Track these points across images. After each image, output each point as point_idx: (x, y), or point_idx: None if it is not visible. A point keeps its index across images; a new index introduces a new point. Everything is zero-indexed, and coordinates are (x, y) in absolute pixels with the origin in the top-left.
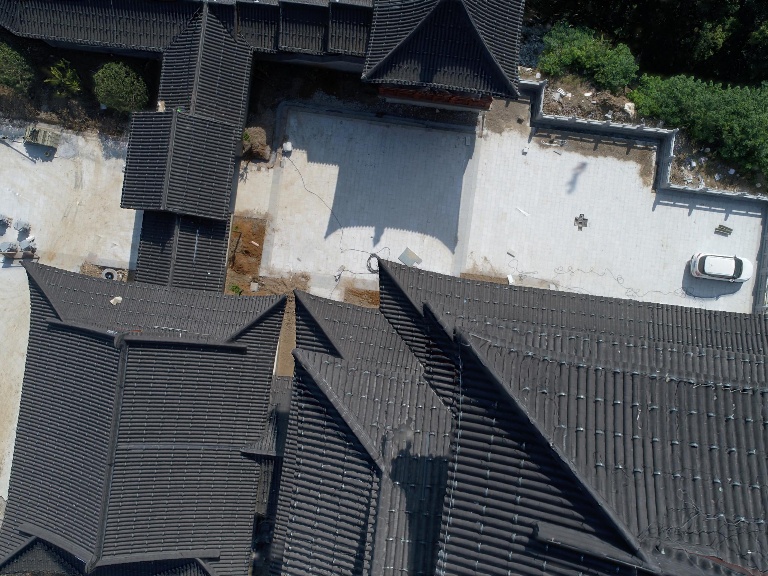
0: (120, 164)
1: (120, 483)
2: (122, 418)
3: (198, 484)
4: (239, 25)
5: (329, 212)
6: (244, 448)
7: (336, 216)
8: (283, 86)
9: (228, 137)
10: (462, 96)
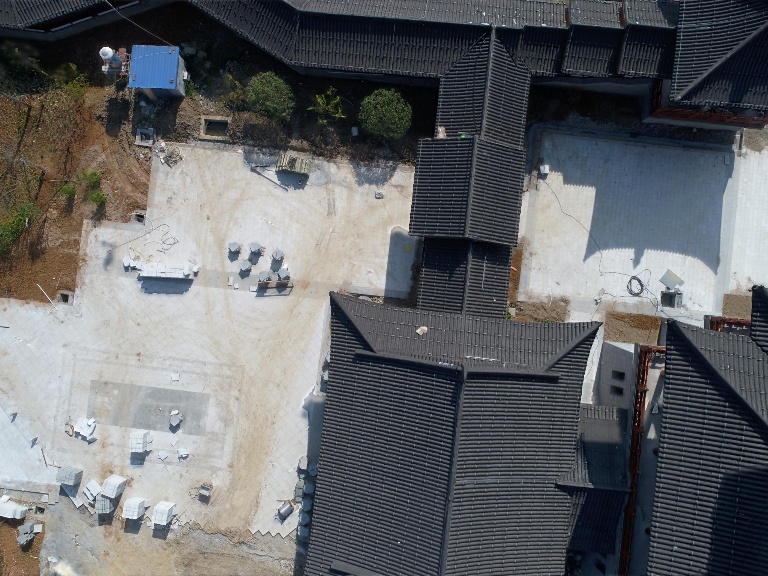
0: (373, 190)
1: (457, 520)
2: (459, 452)
3: (518, 519)
4: (521, 49)
5: (587, 235)
6: (559, 480)
7: (594, 239)
8: (537, 108)
9: (518, 162)
10: (744, 115)
